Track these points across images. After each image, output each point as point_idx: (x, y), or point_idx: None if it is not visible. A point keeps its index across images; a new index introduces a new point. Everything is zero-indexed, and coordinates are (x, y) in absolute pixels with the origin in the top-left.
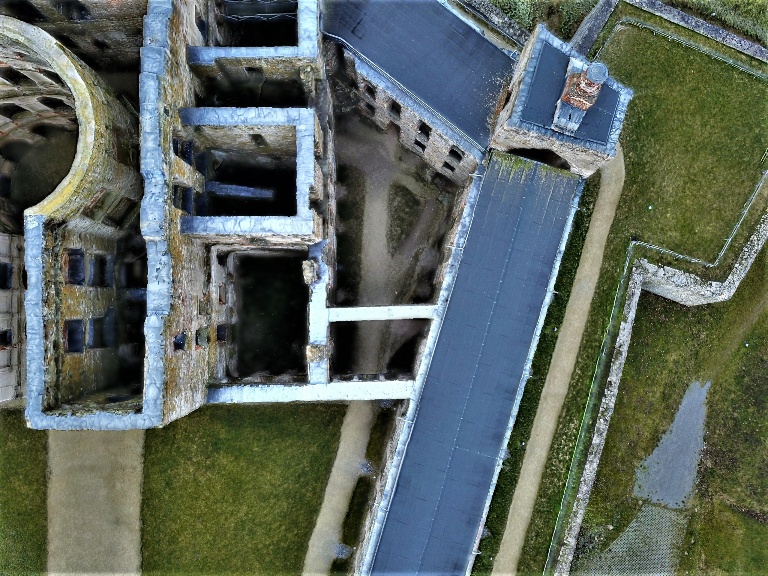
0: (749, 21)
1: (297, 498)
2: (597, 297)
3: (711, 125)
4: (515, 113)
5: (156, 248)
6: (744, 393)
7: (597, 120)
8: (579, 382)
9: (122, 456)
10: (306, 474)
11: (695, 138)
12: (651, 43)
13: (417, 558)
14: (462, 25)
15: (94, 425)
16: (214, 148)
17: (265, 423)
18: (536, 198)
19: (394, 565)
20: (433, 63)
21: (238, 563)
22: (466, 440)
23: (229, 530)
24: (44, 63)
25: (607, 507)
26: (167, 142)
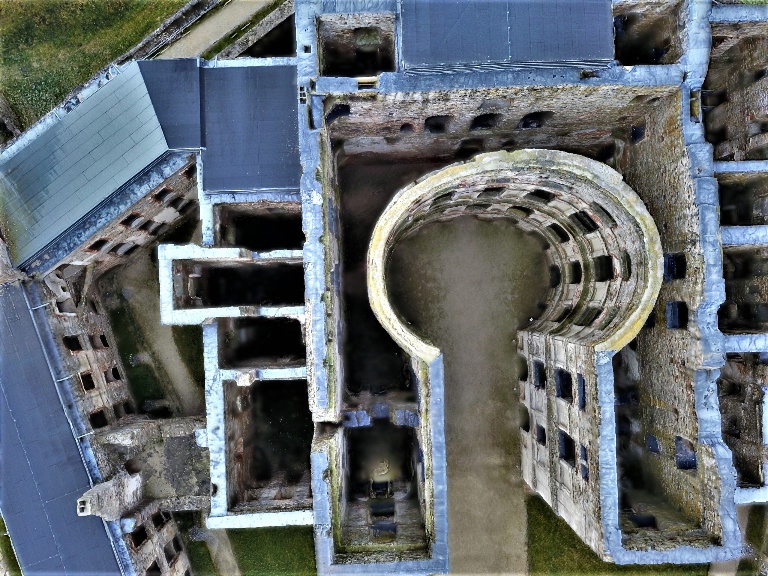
0: None
1: None
2: None
3: None
4: None
5: (706, 376)
6: None
7: None
8: None
9: (505, 545)
10: None
11: None
12: None
13: None
14: None
15: (675, 559)
16: None
17: None
18: None
19: None
20: None
21: None
22: None
23: None
24: (560, 188)
25: None
26: None
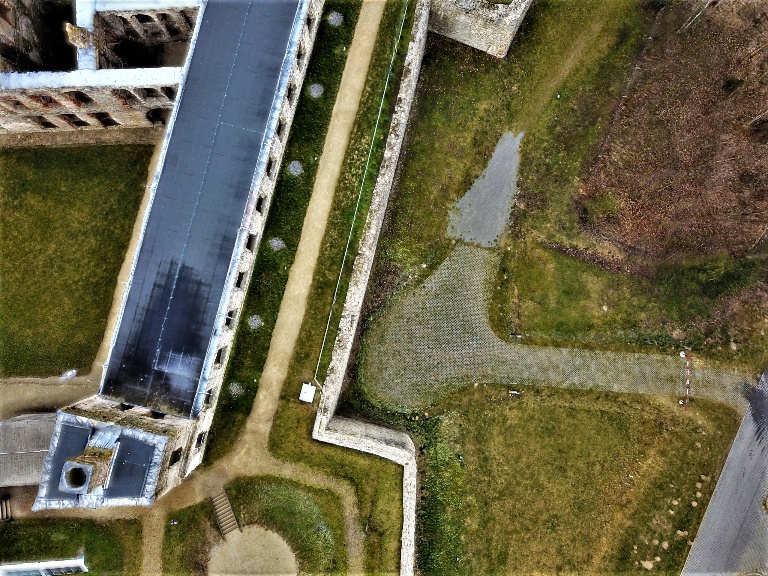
0: None
1: (105, 235)
2: (385, 19)
3: None
4: None
5: None
6: (556, 140)
7: None
8: (369, 99)
9: None
10: (114, 212)
11: None
12: None
13: (185, 231)
14: None
15: None
16: None
17: (72, 164)
18: None
19: (163, 239)
20: None
21: (47, 299)
22: (231, 116)
23: (37, 268)
24: None
25: (421, 247)
26: None
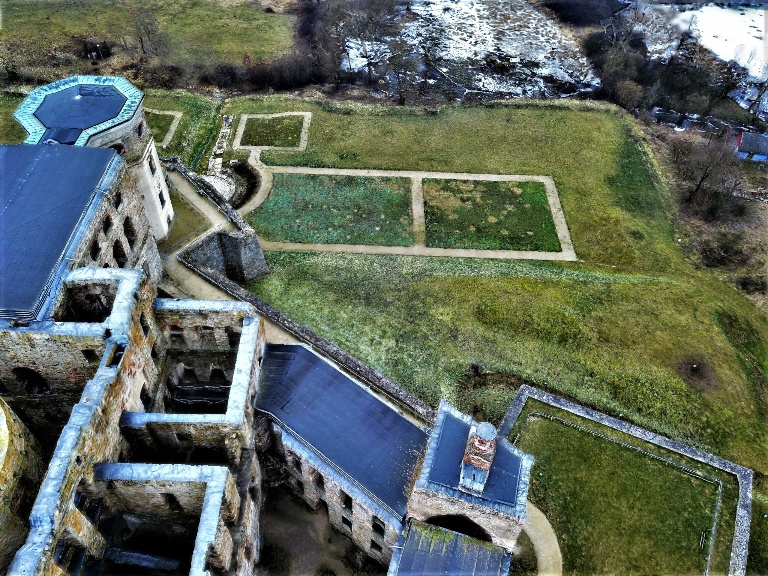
0: (654, 421)
1: None
2: None
3: (638, 508)
4: (423, 474)
5: None
6: None
7: (502, 482)
8: None
9: None
10: None
11: (626, 520)
12: (563, 432)
13: None
14: (381, 405)
15: None
16: (127, 513)
17: None
18: (459, 573)
19: None
20: (354, 436)
21: None
22: None
23: None
24: None
25: None
26: (70, 491)
